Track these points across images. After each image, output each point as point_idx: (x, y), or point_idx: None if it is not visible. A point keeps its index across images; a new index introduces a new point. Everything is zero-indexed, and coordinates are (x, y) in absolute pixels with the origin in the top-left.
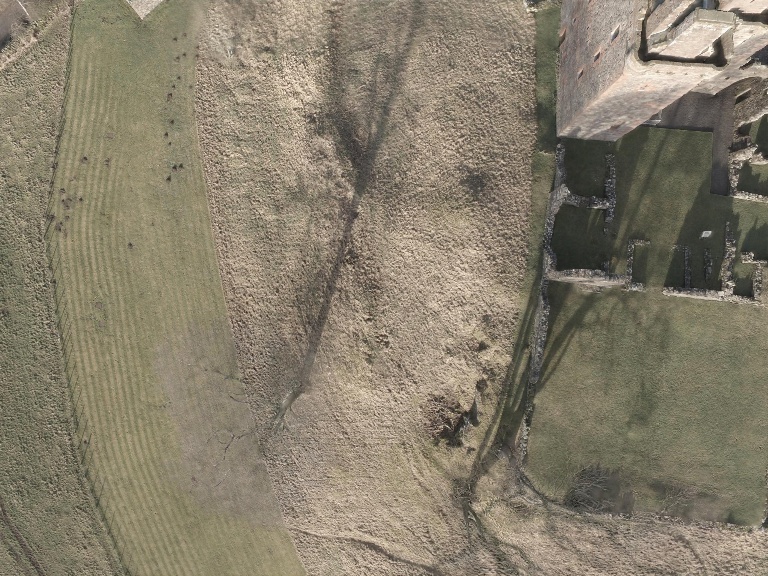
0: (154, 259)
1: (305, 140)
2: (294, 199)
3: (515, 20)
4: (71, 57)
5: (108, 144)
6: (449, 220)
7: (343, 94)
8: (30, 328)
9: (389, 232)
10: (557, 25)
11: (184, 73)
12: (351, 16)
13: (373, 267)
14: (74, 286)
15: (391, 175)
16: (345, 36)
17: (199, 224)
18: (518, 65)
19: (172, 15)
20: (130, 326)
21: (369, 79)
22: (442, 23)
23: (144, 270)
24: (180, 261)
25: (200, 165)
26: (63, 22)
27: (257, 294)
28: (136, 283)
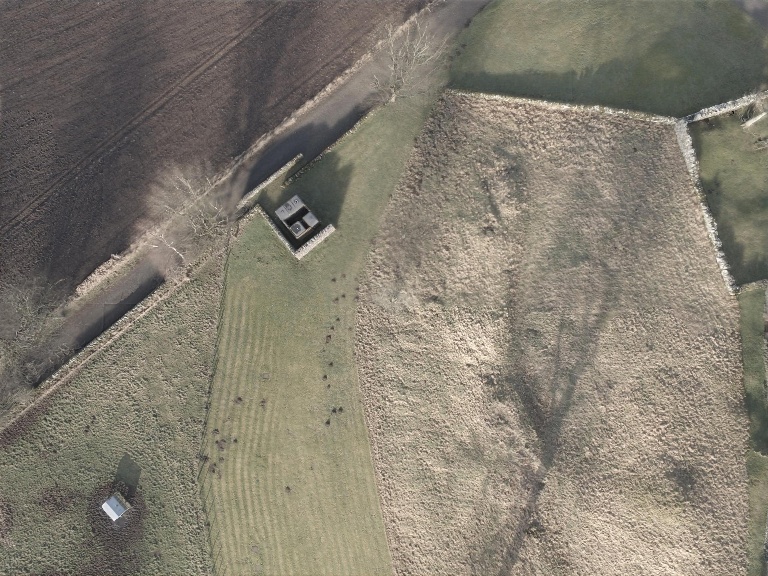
0: (313, 504)
1: (482, 401)
2: (467, 456)
3: (716, 301)
4: (225, 296)
5: (264, 385)
6: (655, 514)
7: (522, 355)
8: (183, 571)
9: (581, 510)
10: (762, 308)
11: (343, 315)
12: (528, 273)
13: (561, 542)
14: (229, 529)
15: (580, 448)
16: (522, 294)
17: (360, 469)
18: (723, 351)
19: (330, 255)
20: (288, 572)
21: (551, 343)
22: (636, 299)
23: (303, 515)
24: (341, 507)
25: (361, 409)
26: (217, 262)
27: (424, 546)
28: (294, 528)
